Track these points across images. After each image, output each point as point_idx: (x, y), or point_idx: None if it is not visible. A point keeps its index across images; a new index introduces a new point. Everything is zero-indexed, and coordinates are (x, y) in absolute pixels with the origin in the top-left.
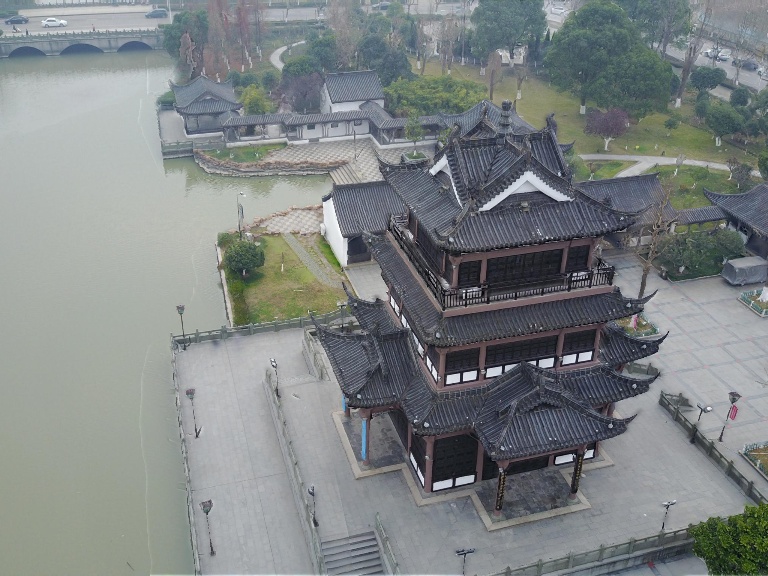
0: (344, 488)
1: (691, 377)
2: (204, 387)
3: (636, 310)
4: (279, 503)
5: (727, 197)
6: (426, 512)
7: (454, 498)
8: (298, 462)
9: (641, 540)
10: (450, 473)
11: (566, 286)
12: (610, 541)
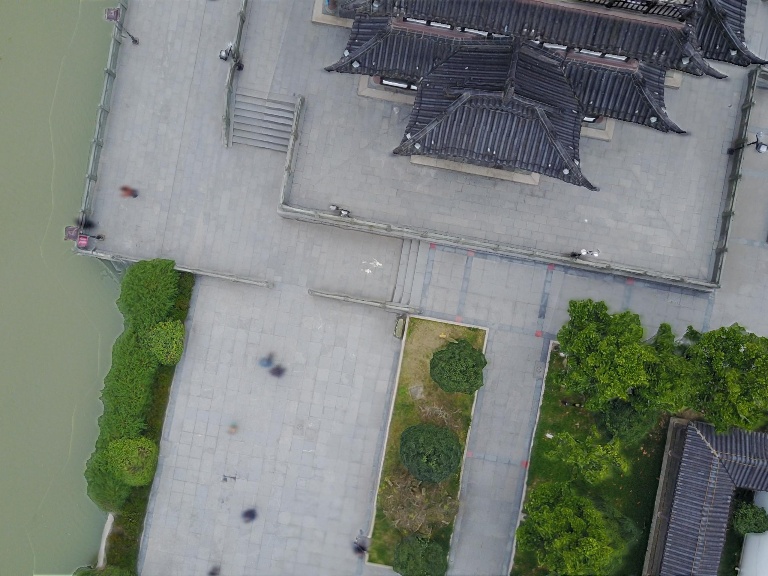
0: (293, 28)
1: None
2: None
3: (691, 71)
4: (227, 1)
5: None
6: (362, 105)
7: (401, 102)
8: None
9: (546, 257)
10: (404, 80)
11: (606, 1)
12: (523, 233)
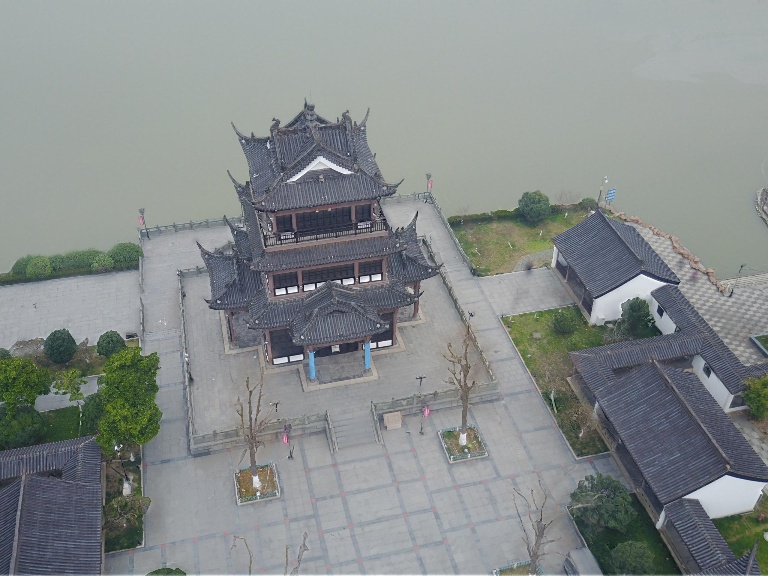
0: None
1: (379, 465)
2: (384, 213)
3: None
4: None
5: (744, 573)
6: None
7: None
8: None
9: None
10: None
11: None
12: (198, 358)
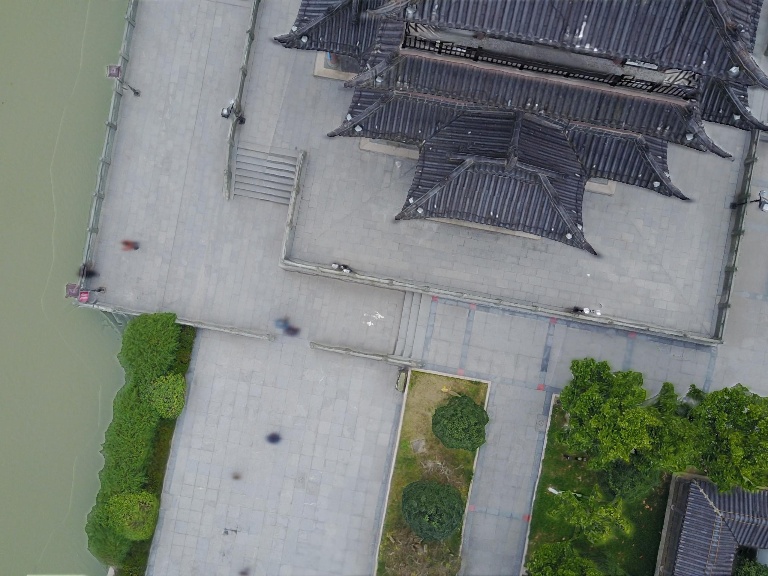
0: (295, 82)
1: None
2: None
3: (695, 146)
4: (229, 54)
5: None
6: (364, 159)
7: (403, 156)
8: (262, 15)
9: (548, 312)
10: None
11: (610, 80)
12: (525, 288)
